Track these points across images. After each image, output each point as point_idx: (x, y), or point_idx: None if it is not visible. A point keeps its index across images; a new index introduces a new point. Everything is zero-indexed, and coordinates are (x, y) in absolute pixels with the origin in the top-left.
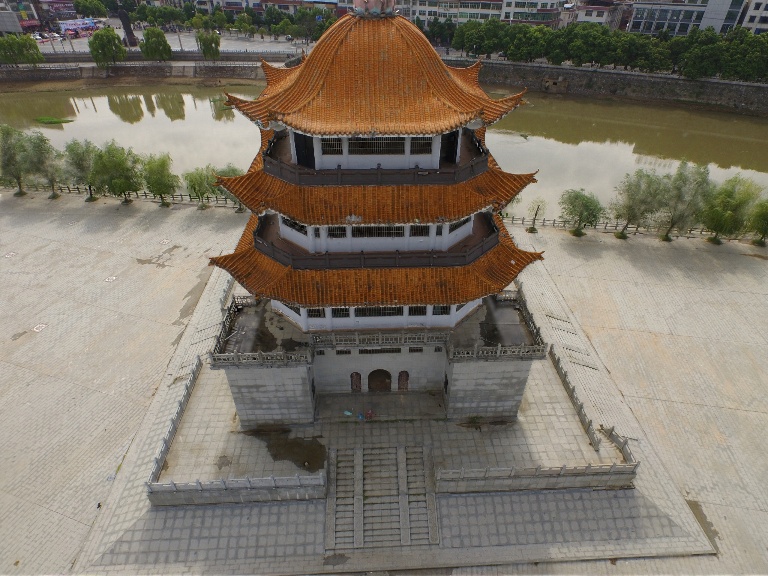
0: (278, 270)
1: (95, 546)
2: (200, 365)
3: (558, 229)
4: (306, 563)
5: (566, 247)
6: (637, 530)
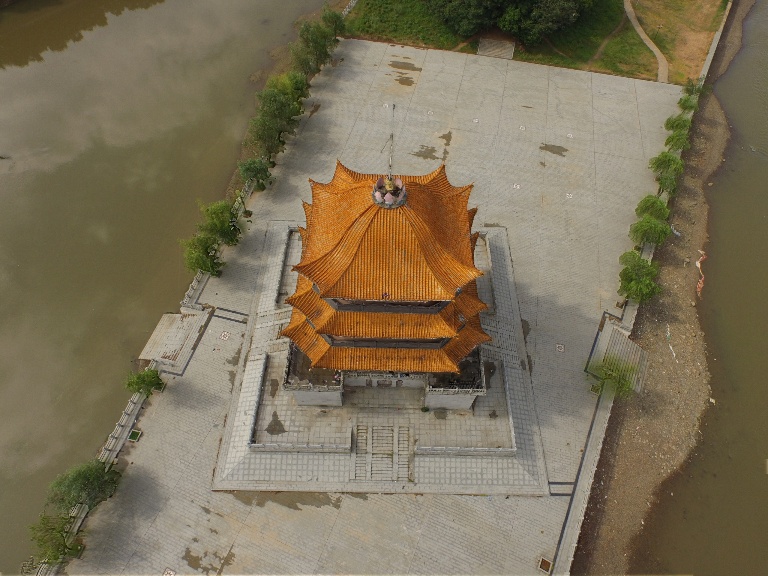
0: (460, 335)
1: (530, 488)
2: (418, 449)
3: (250, 197)
4: (526, 378)
5: (278, 201)
6: (500, 248)
